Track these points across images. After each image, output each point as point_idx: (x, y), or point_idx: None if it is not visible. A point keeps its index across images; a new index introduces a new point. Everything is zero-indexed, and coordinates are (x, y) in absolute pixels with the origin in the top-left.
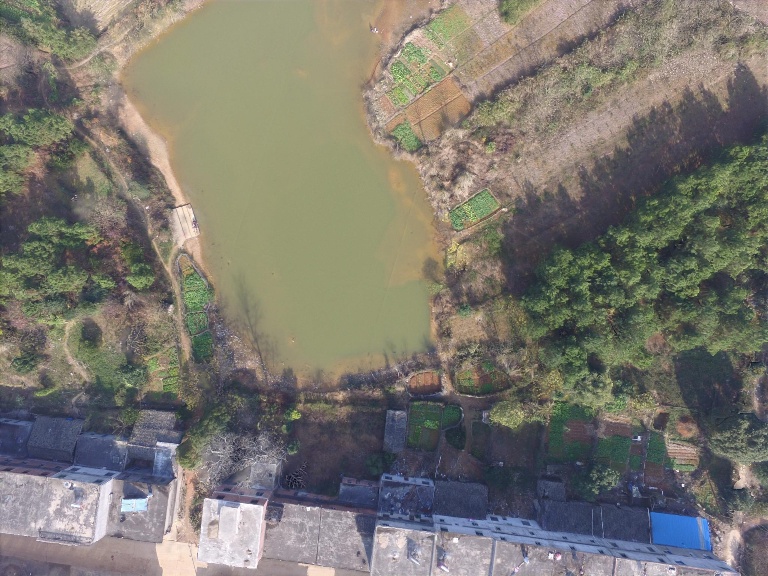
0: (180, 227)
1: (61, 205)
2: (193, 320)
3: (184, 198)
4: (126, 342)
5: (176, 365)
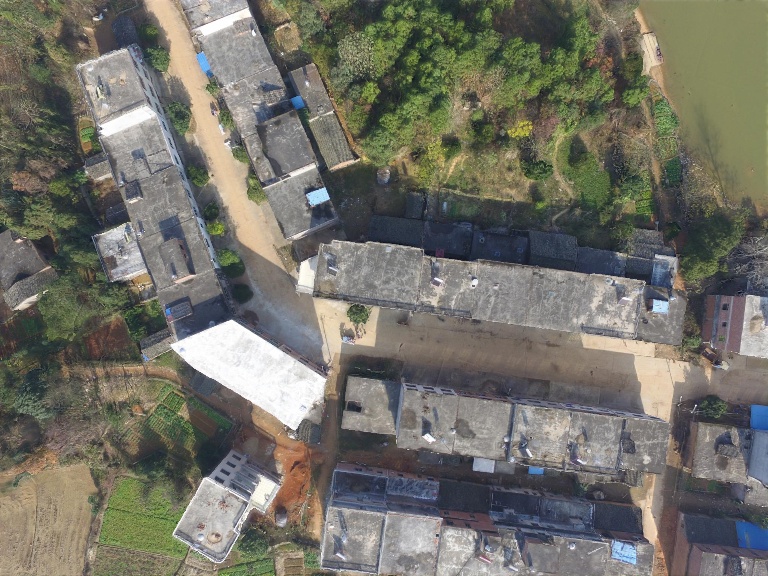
0: (647, 54)
1: (547, 20)
2: (664, 145)
3: (647, 26)
4: (608, 161)
5: (649, 188)
